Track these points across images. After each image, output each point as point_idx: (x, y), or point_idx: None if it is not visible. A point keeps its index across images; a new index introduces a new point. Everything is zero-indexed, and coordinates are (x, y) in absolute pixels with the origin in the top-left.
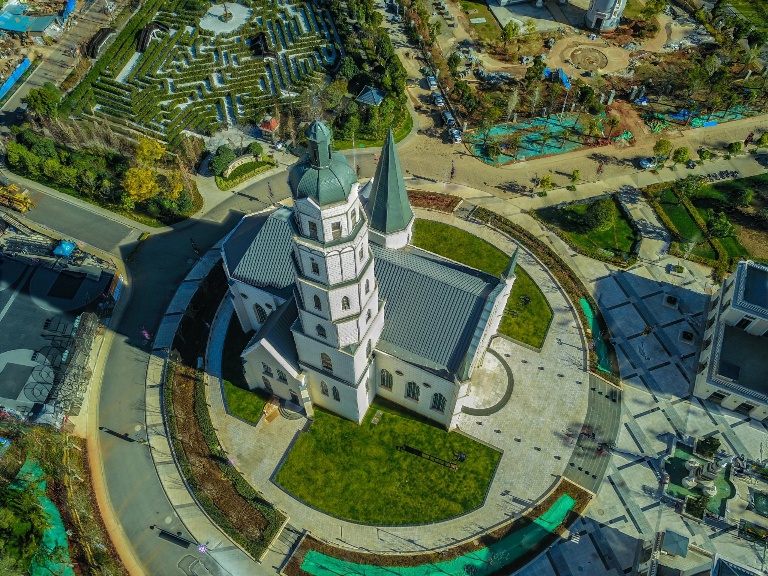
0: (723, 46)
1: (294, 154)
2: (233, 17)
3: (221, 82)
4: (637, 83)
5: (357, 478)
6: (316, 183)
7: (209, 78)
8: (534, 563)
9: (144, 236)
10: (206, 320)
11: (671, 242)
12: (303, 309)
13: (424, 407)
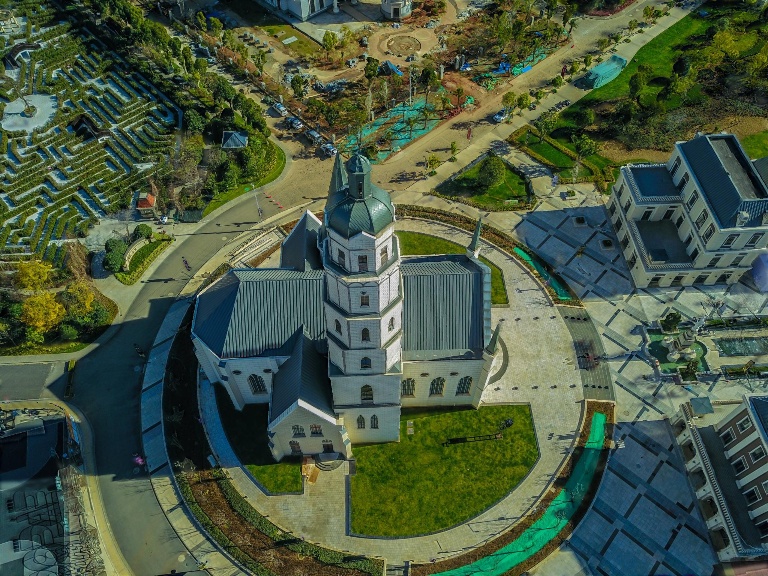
0: (502, 3)
1: (185, 222)
2: (37, 109)
3: (63, 178)
4: (453, 54)
5: (425, 490)
6: (367, 215)
7: (48, 179)
8: (604, 481)
9: (71, 365)
10: (192, 417)
11: (553, 174)
12: (348, 349)
13: (449, 397)
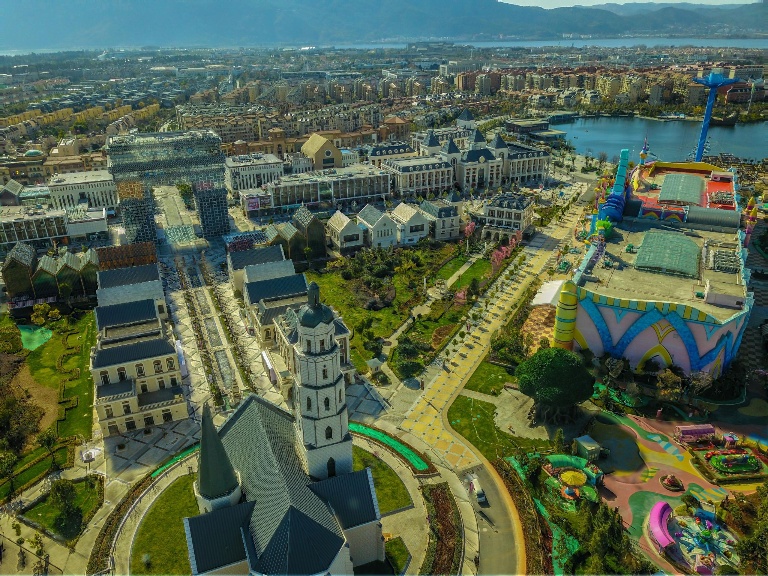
0: None
1: None
2: None
3: None
4: None
5: None
6: None
7: None
8: None
9: None
10: None
11: (60, 469)
12: None
13: None
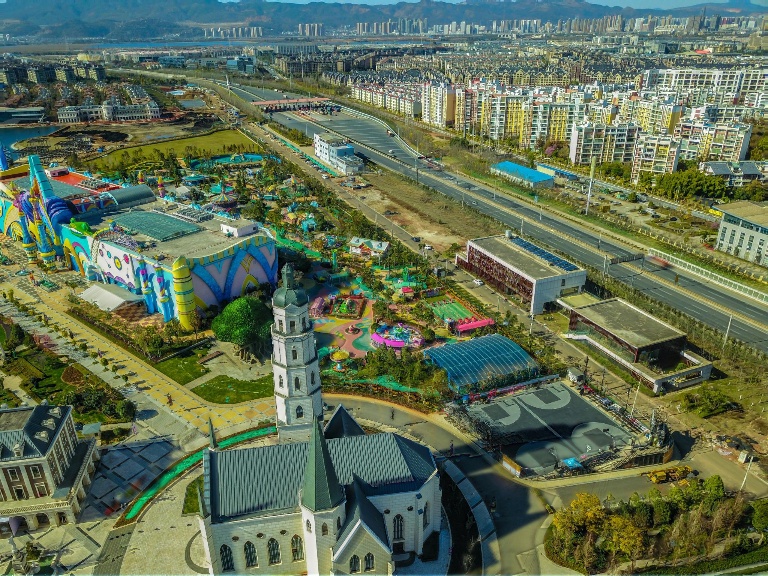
0: None
1: None
2: None
3: None
4: None
5: None
6: None
7: None
8: None
9: (549, 508)
10: None
11: None
12: None
13: None
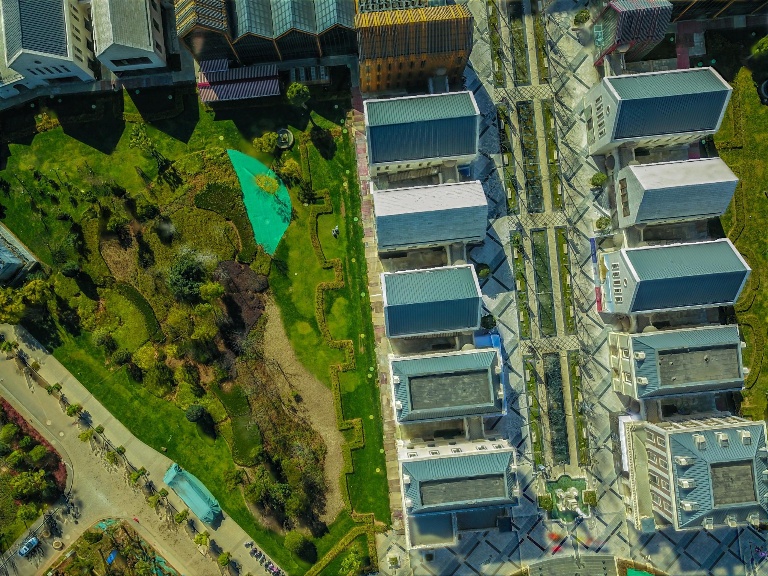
0: None
1: None
2: None
3: None
4: None
5: None
6: None
7: None
8: None
9: None
10: None
11: None
12: None
13: None
